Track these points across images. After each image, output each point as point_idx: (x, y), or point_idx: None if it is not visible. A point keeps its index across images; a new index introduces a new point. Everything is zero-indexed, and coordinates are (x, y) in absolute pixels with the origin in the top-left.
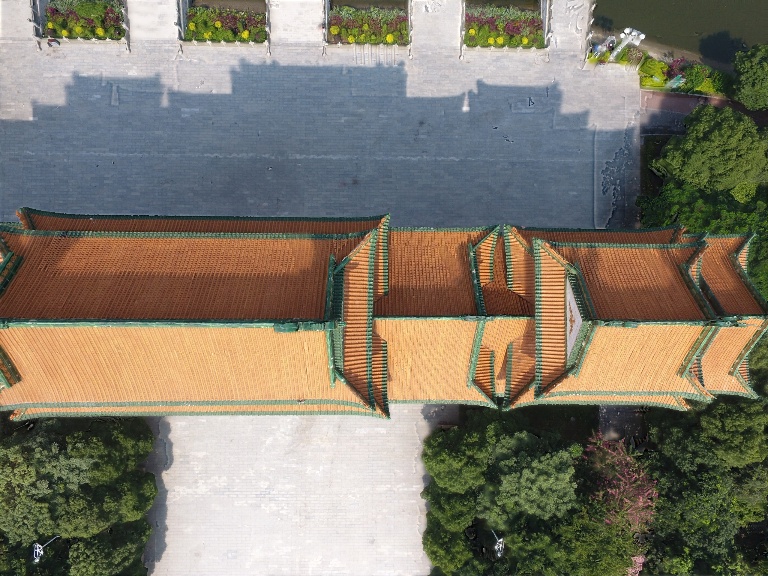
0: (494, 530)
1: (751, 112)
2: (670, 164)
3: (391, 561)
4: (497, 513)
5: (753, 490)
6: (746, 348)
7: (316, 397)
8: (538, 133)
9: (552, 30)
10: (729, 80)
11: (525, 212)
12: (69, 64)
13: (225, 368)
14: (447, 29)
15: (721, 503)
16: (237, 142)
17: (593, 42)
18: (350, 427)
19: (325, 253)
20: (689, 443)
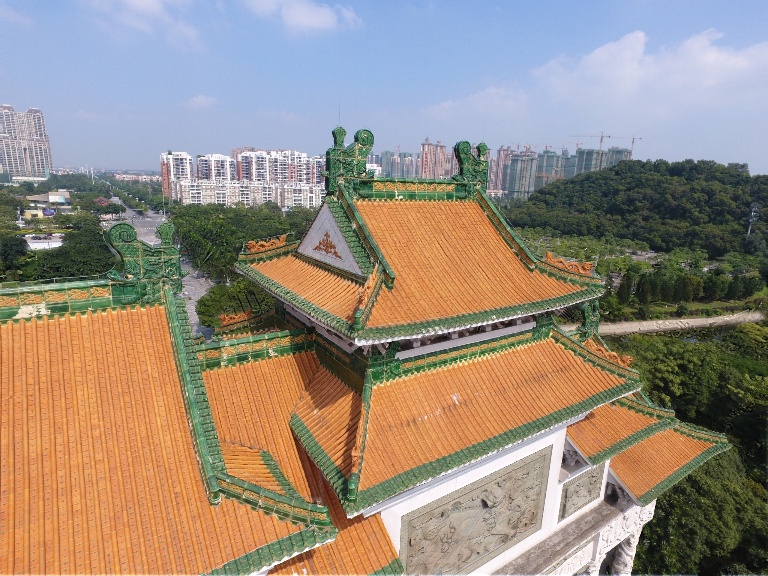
0: None
1: None
2: None
3: None
4: None
5: None
6: None
7: None
8: None
9: None
10: None
11: None
12: None
13: None
14: None
15: None
16: None
17: None
18: None
19: None
20: None
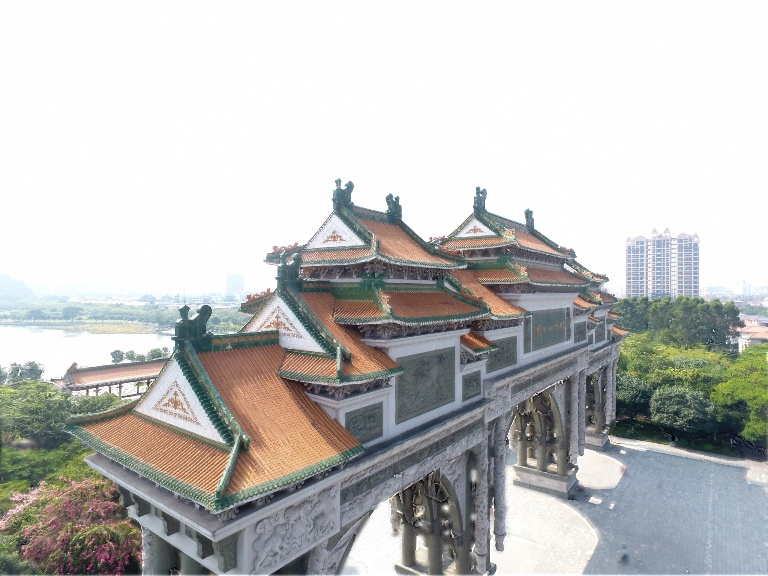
0: None
1: None
2: None
3: None
4: None
5: None
6: None
7: None
8: None
9: None
10: None
11: None
12: None
13: None
14: None
15: None
16: (729, 563)
17: None
18: None
19: None
20: None
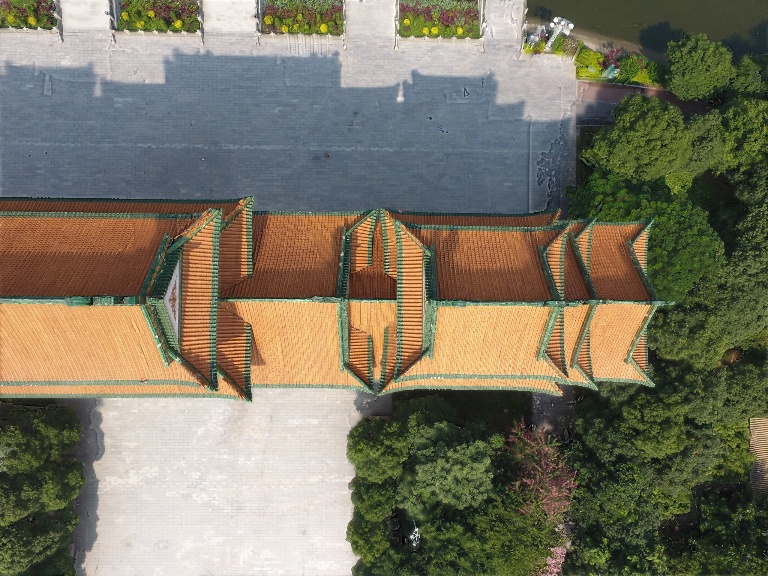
0: (415, 520)
1: (688, 103)
2: (597, 154)
3: (323, 552)
4: (413, 503)
5: (673, 481)
6: (637, 335)
7: (158, 377)
8: (473, 124)
9: (485, 20)
10: (664, 70)
11: (459, 203)
12: (2, 53)
13: (59, 347)
14: (381, 19)
15: (639, 494)
16: (170, 132)
17: (530, 32)
18: (282, 418)
19: (166, 232)
20: (609, 434)
